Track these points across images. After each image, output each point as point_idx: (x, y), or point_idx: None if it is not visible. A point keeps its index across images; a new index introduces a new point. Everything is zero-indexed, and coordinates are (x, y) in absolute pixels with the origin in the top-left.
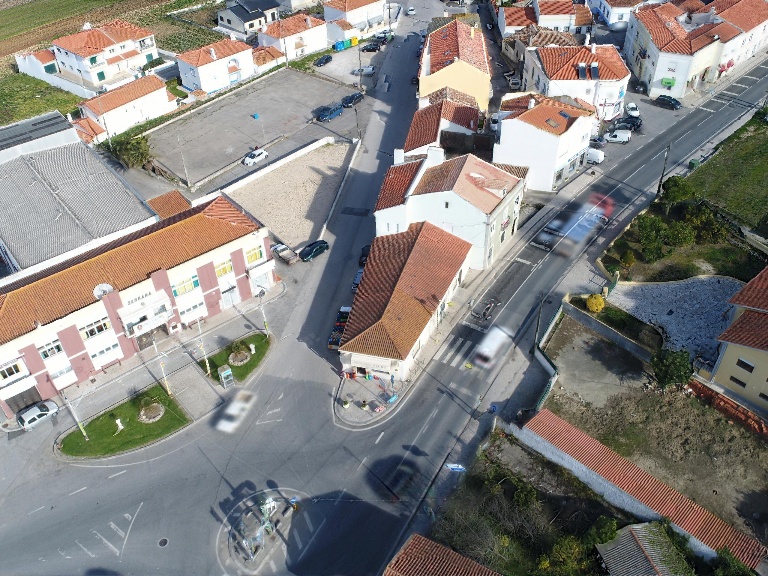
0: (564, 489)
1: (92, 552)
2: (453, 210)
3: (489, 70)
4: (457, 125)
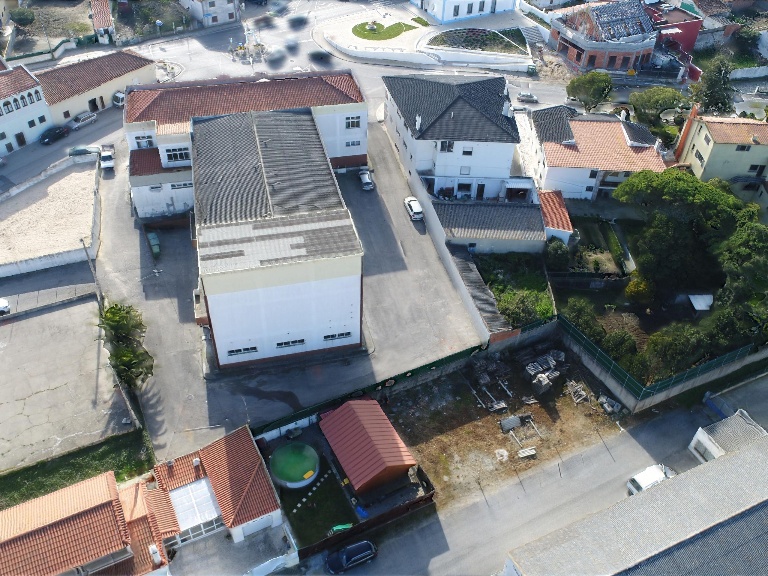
0: None
1: (324, 69)
2: None
3: None
4: None
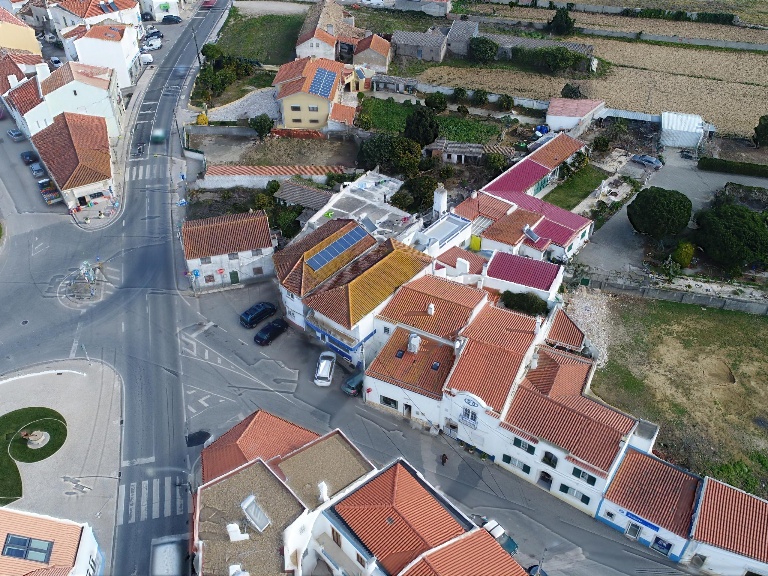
0: (244, 196)
1: None
2: (81, 95)
3: (29, 27)
4: (32, 66)
